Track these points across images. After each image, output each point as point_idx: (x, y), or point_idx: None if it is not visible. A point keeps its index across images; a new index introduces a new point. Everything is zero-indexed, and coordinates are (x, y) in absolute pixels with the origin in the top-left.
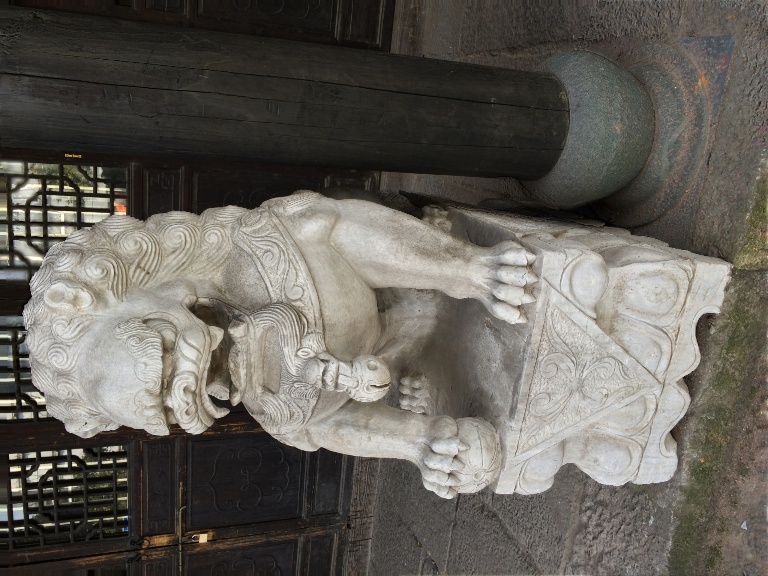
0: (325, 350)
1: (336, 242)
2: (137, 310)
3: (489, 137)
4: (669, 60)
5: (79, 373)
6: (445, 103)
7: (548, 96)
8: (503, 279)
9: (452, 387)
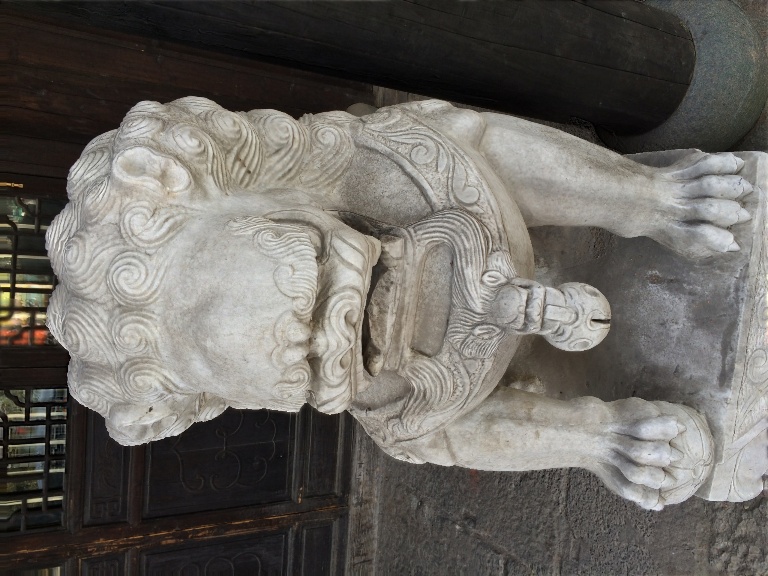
0: (517, 275)
1: (487, 152)
2: (252, 207)
3: (622, 57)
4: (766, 7)
5: (164, 302)
6: (579, 8)
7: (671, 22)
8: (712, 189)
9: (589, 382)
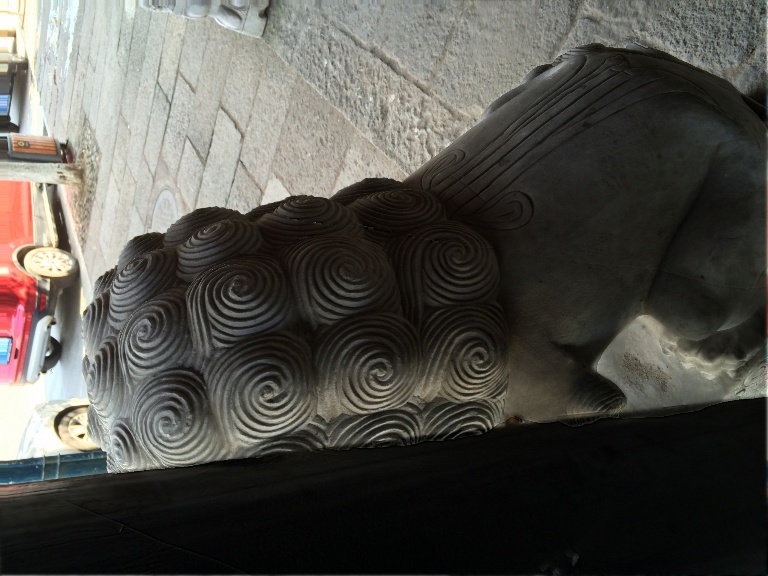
0: None
1: None
2: None
3: None
4: None
5: None
6: None
7: None
8: None
9: None
